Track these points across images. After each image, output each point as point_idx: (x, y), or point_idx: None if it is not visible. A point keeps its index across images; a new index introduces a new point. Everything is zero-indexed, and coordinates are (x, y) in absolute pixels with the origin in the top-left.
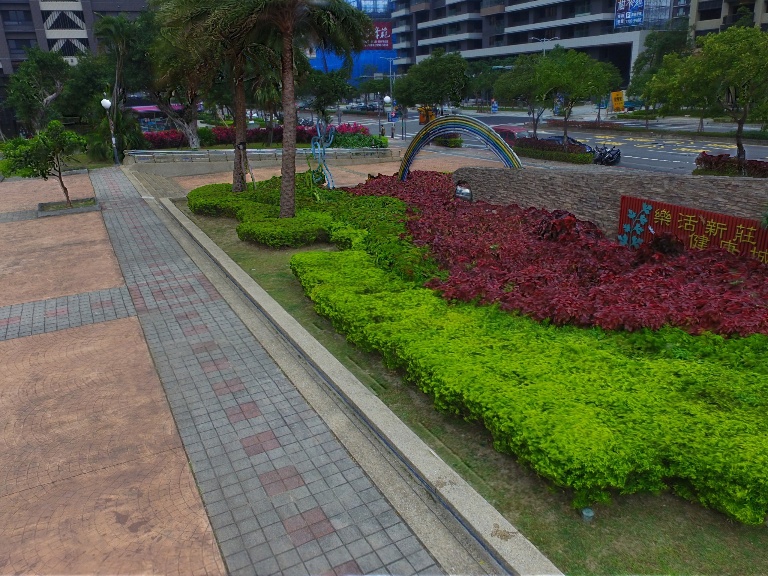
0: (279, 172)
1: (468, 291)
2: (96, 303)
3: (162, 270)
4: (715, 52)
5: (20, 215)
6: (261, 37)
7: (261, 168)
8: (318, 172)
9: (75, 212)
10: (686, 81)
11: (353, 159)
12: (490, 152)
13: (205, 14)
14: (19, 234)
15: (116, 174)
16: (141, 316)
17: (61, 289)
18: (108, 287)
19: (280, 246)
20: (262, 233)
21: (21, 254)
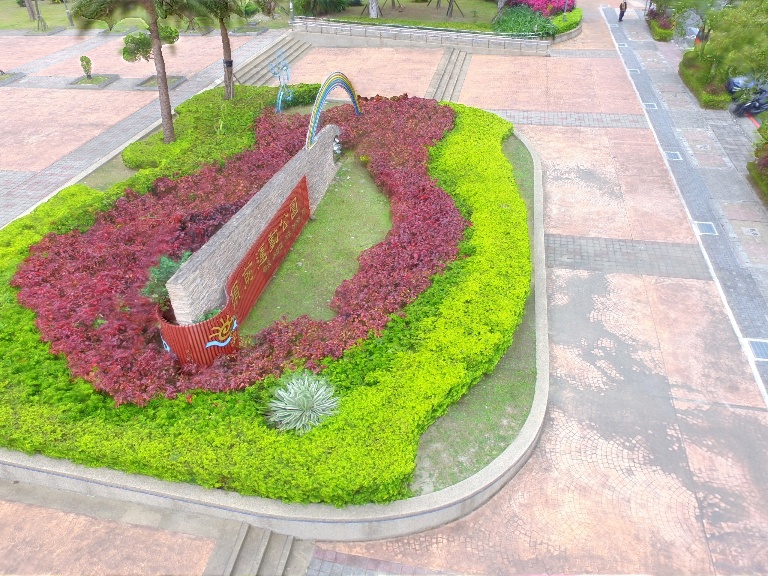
0: (388, 58)
1: (33, 248)
2: (8, 181)
3: (72, 165)
4: (747, 22)
5: (135, 84)
6: (130, 14)
7: (392, 48)
8: (317, 86)
9: (154, 90)
10: (712, 52)
11: (491, 48)
12: (675, 58)
13: (80, 3)
14: (98, 106)
15: (266, 42)
16: (1, 198)
17: (20, 164)
18: (34, 170)
19: (129, 167)
20: (122, 155)
21: (64, 127)
